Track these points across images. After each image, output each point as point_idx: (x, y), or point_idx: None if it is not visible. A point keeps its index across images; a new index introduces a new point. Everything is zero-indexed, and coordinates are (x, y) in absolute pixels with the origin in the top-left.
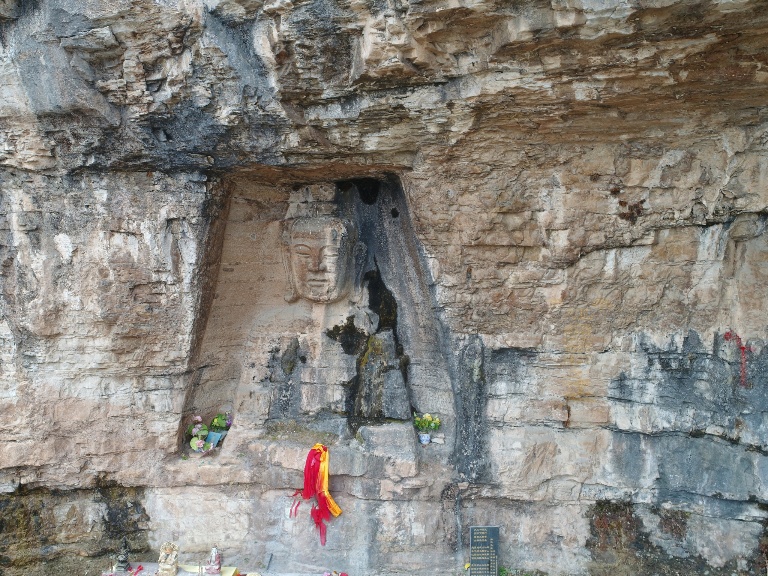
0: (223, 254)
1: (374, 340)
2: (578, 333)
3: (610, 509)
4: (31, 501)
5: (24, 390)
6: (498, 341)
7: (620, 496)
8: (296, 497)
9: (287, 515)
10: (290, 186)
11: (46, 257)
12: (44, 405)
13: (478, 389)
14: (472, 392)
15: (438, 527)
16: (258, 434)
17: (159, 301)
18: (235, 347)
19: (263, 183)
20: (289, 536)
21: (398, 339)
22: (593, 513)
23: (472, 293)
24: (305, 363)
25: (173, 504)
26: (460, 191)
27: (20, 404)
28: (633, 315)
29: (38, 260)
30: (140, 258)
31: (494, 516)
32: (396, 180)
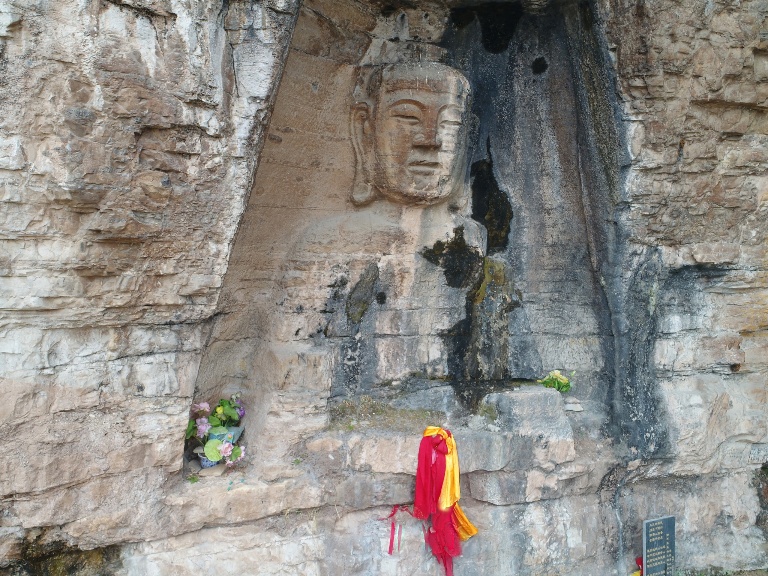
0: None
1: (492, 264)
2: None
3: None
4: None
5: None
6: (680, 256)
7: None
8: (393, 519)
9: (384, 551)
10: (380, 5)
11: None
12: None
13: (651, 326)
14: (644, 330)
15: None
16: (323, 422)
17: (184, 170)
18: (259, 282)
19: None
20: None
21: None
22: (759, 480)
23: (675, 180)
24: (383, 304)
25: (182, 567)
26: (720, 6)
27: None
28: None
29: None
30: (160, 70)
31: (654, 502)
32: (564, 6)
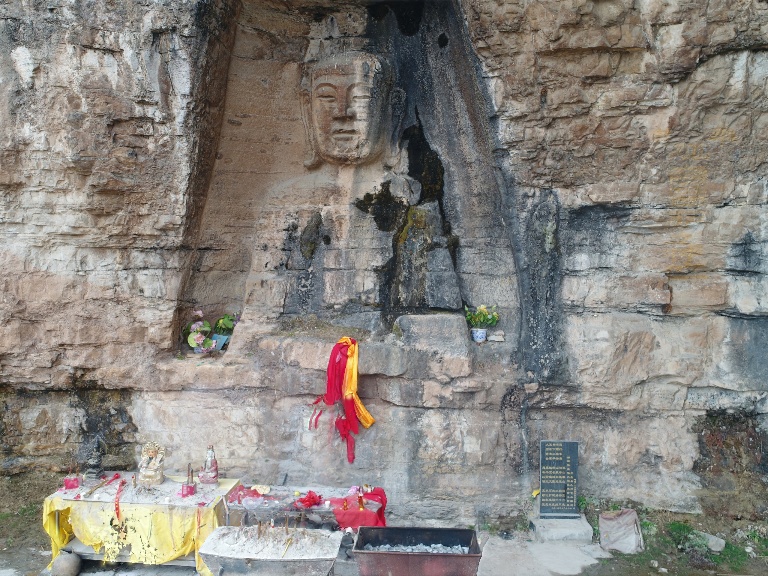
0: (227, 100)
1: (415, 211)
2: (689, 179)
3: (725, 422)
4: None
5: None
6: (578, 197)
7: (740, 403)
8: (317, 405)
9: (306, 427)
10: (311, 14)
11: (2, 80)
12: (5, 278)
13: (551, 262)
14: (543, 266)
15: (498, 443)
16: (271, 329)
17: (145, 146)
18: (244, 229)
19: (277, 8)
20: (308, 452)
21: (445, 215)
22: (702, 427)
23: (547, 126)
24: (329, 244)
25: (166, 412)
26: None
27: None
28: (766, 151)
29: None
30: (120, 84)
31: (570, 431)
32: None
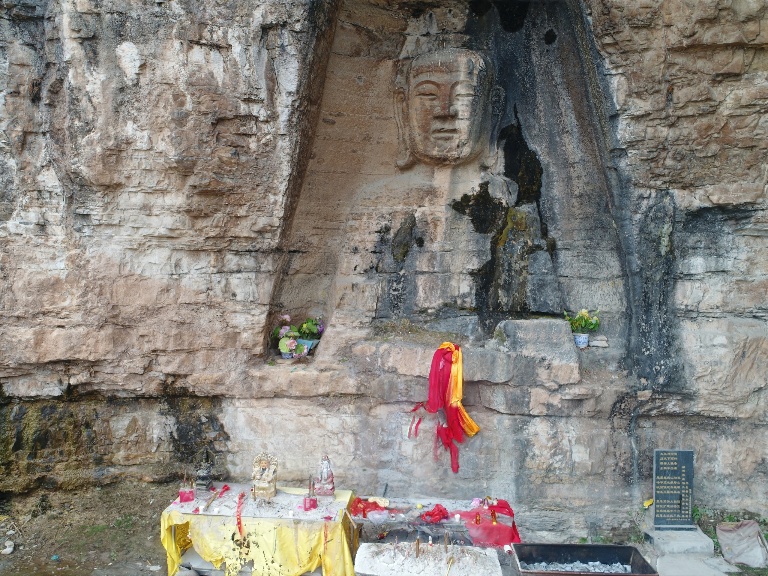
0: (323, 98)
1: (515, 212)
2: None
3: None
4: (82, 409)
5: (75, 261)
6: (696, 199)
7: None
8: (415, 413)
9: (405, 435)
10: (409, 10)
11: (105, 76)
12: (100, 282)
13: (666, 266)
14: (657, 270)
15: (607, 452)
16: (365, 334)
17: (247, 145)
18: (331, 231)
19: (376, 4)
20: (408, 462)
21: (541, 216)
22: None
23: (670, 125)
24: (422, 247)
25: (258, 419)
26: None
27: (70, 279)
28: None
29: (95, 80)
30: (225, 81)
31: (681, 439)
32: None
